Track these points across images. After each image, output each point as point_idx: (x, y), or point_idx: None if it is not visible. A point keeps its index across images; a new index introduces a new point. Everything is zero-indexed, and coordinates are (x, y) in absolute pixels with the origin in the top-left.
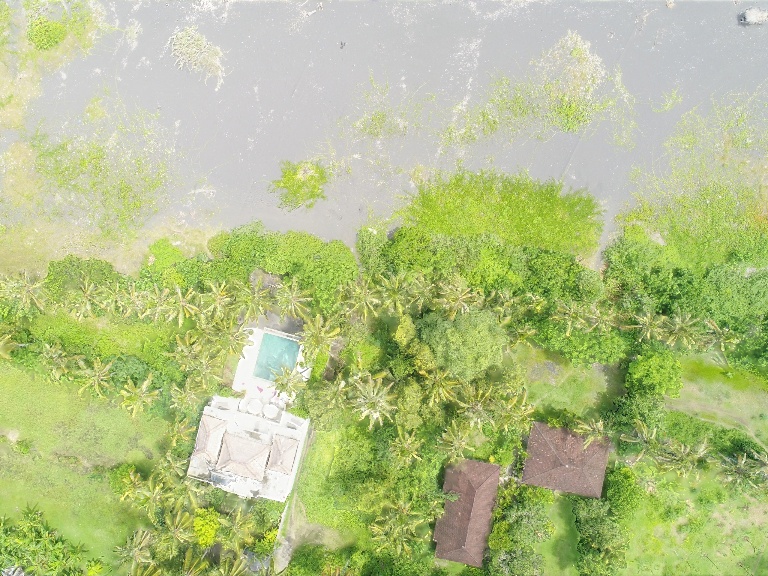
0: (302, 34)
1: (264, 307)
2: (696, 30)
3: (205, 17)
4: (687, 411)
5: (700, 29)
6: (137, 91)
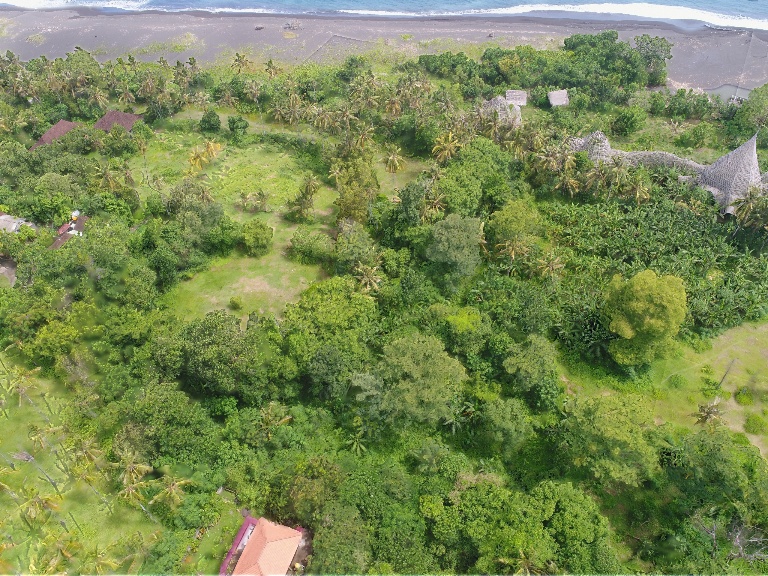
0: (81, 35)
1: (2, 65)
2: (238, 31)
3: (46, 32)
4: (194, 119)
5: (240, 31)
6: (4, 47)
